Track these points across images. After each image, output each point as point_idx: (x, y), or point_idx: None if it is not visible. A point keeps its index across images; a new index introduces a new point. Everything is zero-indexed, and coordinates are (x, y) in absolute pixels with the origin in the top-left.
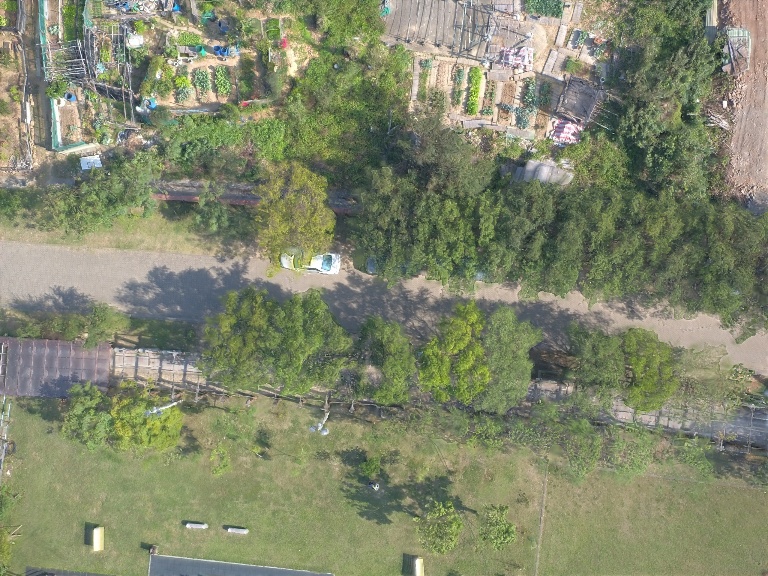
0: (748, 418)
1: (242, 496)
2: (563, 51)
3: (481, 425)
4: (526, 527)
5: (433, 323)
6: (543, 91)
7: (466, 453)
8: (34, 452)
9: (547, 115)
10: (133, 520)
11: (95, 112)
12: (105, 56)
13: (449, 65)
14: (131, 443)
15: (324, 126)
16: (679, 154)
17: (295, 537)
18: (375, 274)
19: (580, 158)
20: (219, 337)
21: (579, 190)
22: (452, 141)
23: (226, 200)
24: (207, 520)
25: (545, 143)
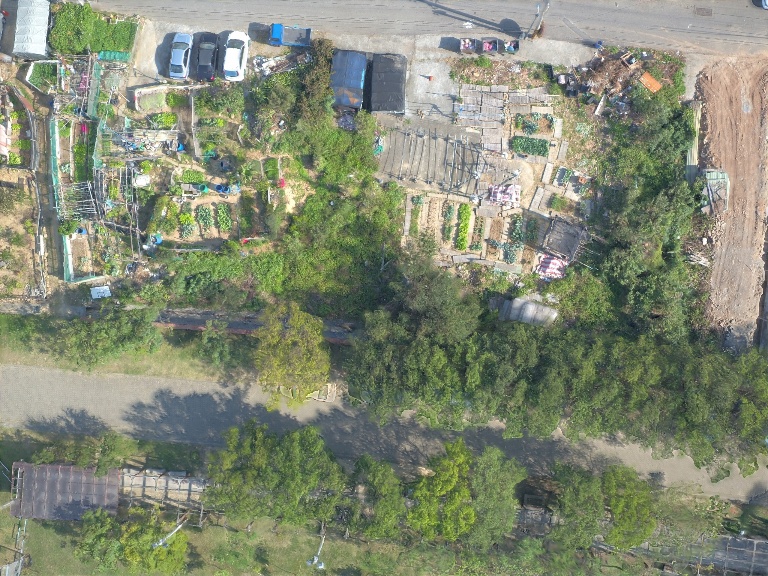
0: (725, 542)
1: None
2: (549, 188)
3: (467, 560)
4: None
5: (424, 448)
6: (530, 227)
7: None
8: (48, 565)
9: (534, 250)
10: None
11: (105, 245)
12: (114, 193)
13: (440, 201)
14: (139, 567)
15: (321, 261)
16: (659, 293)
17: None
18: (369, 402)
19: (565, 292)
20: (221, 474)
21: (562, 334)
22: (441, 286)
23: (228, 336)
24: None
25: (532, 277)
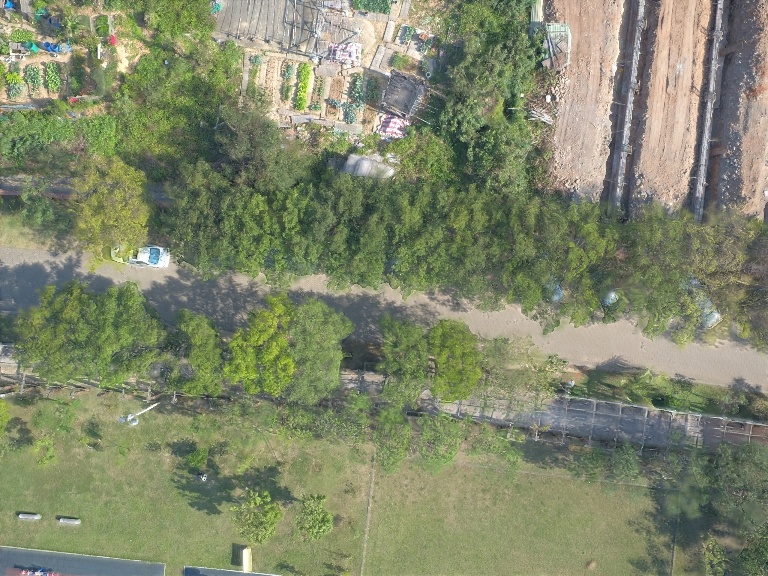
0: None
1: (75, 487)
2: (391, 47)
3: (289, 415)
4: (353, 517)
5: None
6: (370, 86)
7: (295, 444)
8: None
9: (374, 110)
10: None
11: None
12: None
13: (279, 61)
14: None
15: (154, 121)
16: (497, 148)
17: (127, 527)
18: None
19: (405, 152)
20: (31, 329)
21: (391, 183)
22: (267, 135)
23: (50, 194)
24: (40, 510)
25: (372, 137)
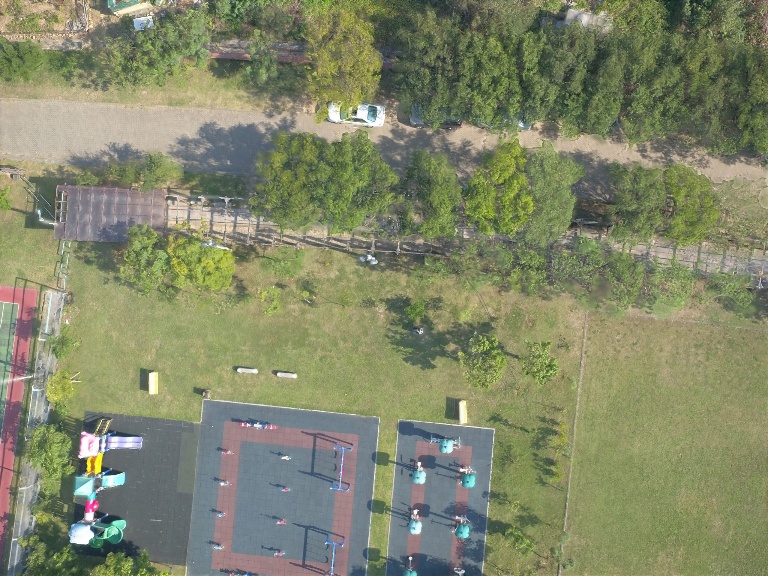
0: None
1: (290, 343)
2: None
3: (525, 255)
4: (566, 371)
5: (475, 174)
6: None
7: (507, 300)
8: (91, 302)
9: None
10: (186, 366)
11: None
12: None
13: None
14: (186, 282)
15: None
16: (718, 0)
17: (342, 382)
18: (419, 126)
19: (619, 10)
20: (272, 172)
21: (620, 30)
22: None
23: (276, 50)
24: (257, 366)
25: None
